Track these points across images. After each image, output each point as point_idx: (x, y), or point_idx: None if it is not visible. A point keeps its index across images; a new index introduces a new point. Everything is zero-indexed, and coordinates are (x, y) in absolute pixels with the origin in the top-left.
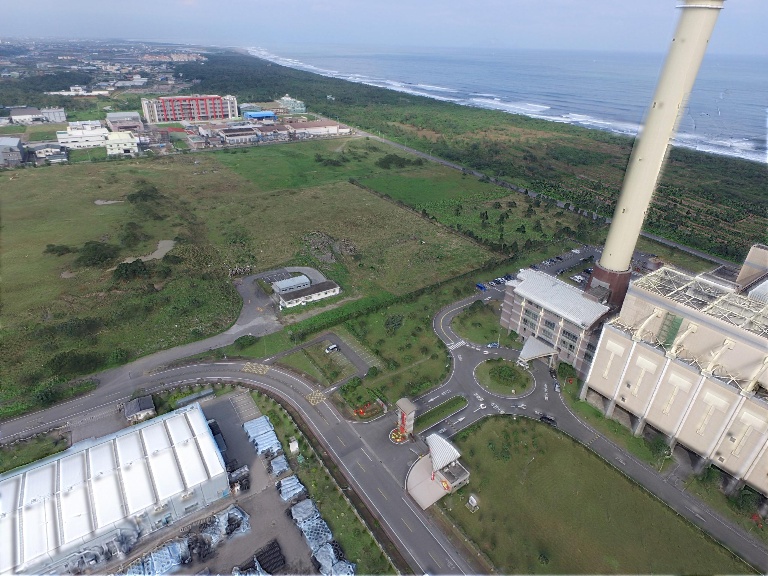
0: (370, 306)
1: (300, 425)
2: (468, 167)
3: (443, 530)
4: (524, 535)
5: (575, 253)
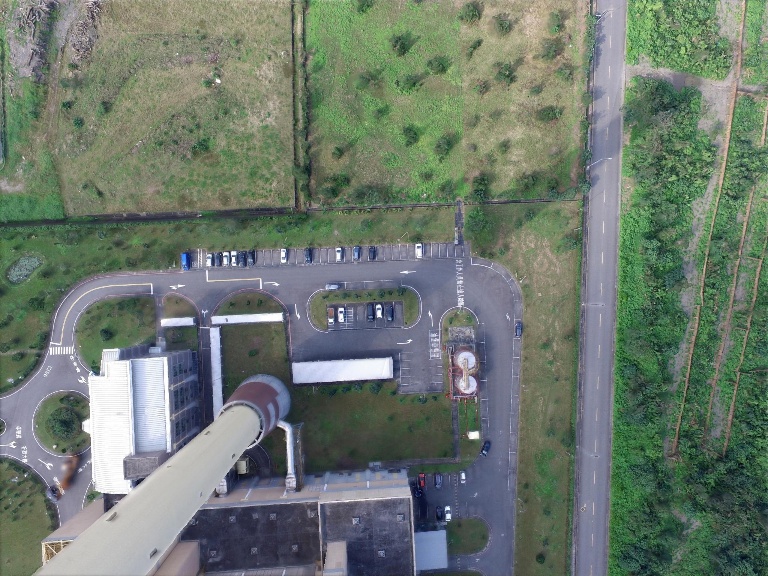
0: (4, 227)
1: None
2: None
3: None
4: None
5: (415, 252)
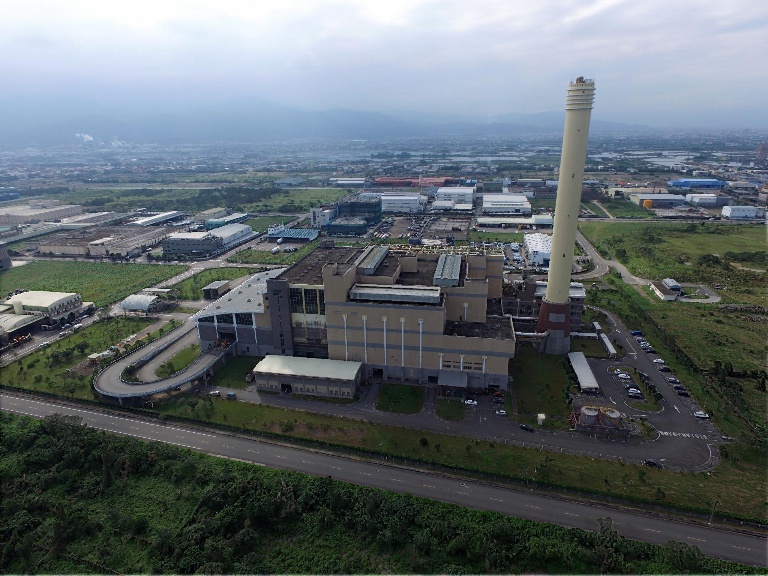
0: None
1: None
2: None
3: None
4: None
5: None
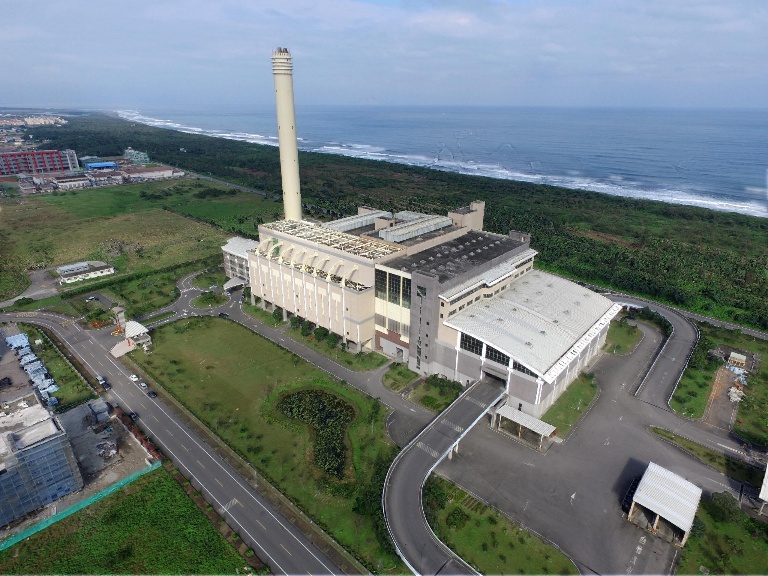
0: None
1: (49, 335)
2: (273, 194)
3: (123, 363)
4: (172, 358)
5: None
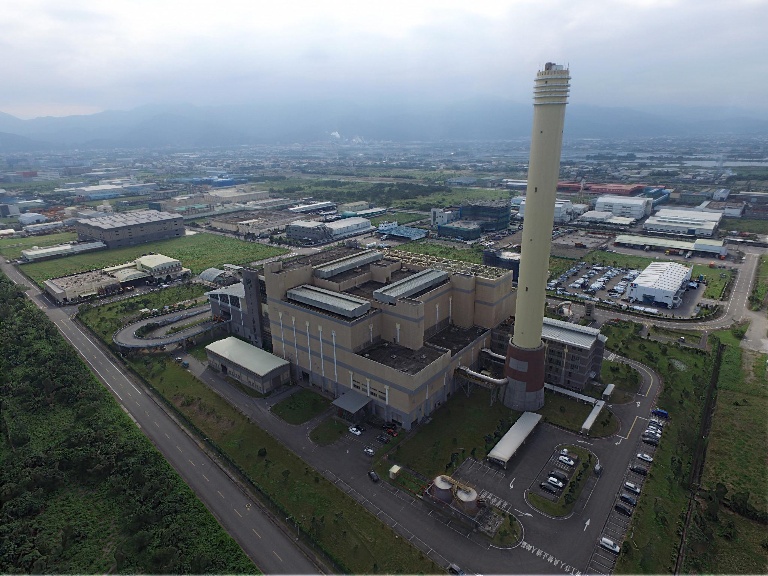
0: None
1: None
2: None
3: None
4: None
5: None
